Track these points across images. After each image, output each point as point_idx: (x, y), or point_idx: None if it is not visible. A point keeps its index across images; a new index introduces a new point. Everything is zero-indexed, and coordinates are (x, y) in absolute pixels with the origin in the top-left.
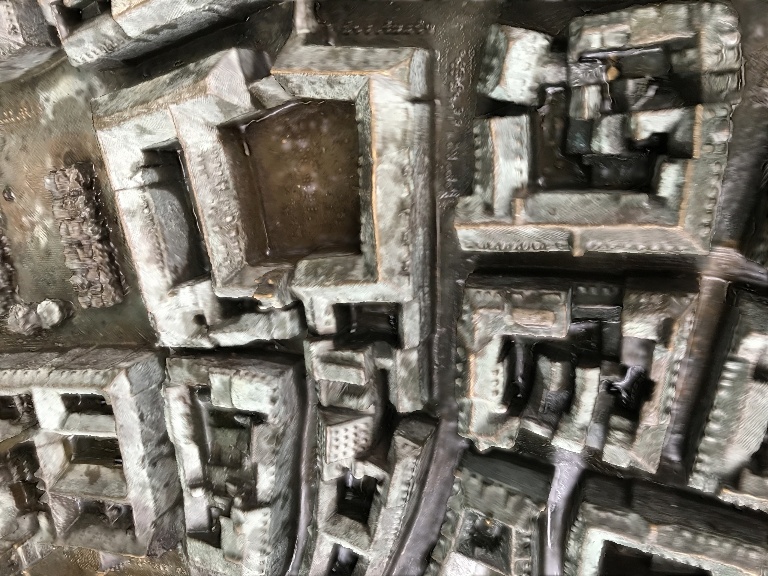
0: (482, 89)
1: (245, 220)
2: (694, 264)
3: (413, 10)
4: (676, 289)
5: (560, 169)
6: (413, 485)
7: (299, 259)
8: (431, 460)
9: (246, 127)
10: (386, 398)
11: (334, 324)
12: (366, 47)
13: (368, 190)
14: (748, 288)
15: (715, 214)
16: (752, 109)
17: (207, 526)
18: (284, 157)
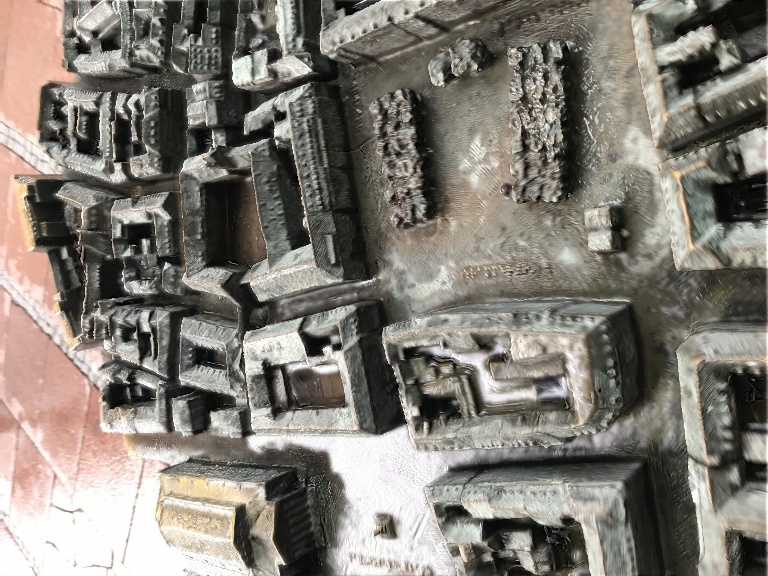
0: (178, 268)
1: None
2: None
3: (227, 308)
4: None
5: None
6: None
7: None
8: None
9: None
10: None
11: None
12: None
13: (191, 222)
14: None
15: None
16: None
17: None
18: None
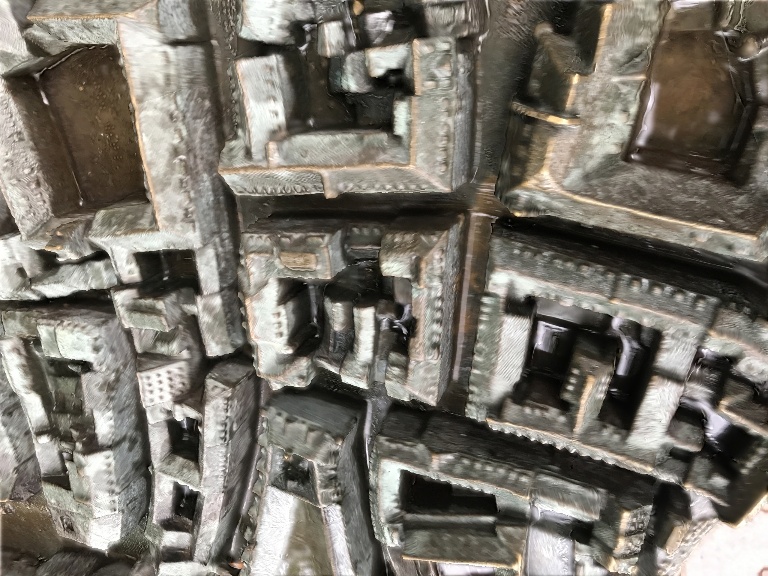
0: (236, 29)
1: (48, 171)
2: (463, 201)
3: None
4: (429, 227)
5: (332, 109)
6: (232, 425)
7: (98, 209)
8: (259, 400)
9: (40, 75)
10: (202, 343)
11: (138, 273)
12: None
13: None
14: (508, 223)
15: (451, 151)
16: (500, 41)
17: (61, 470)
18: (84, 105)
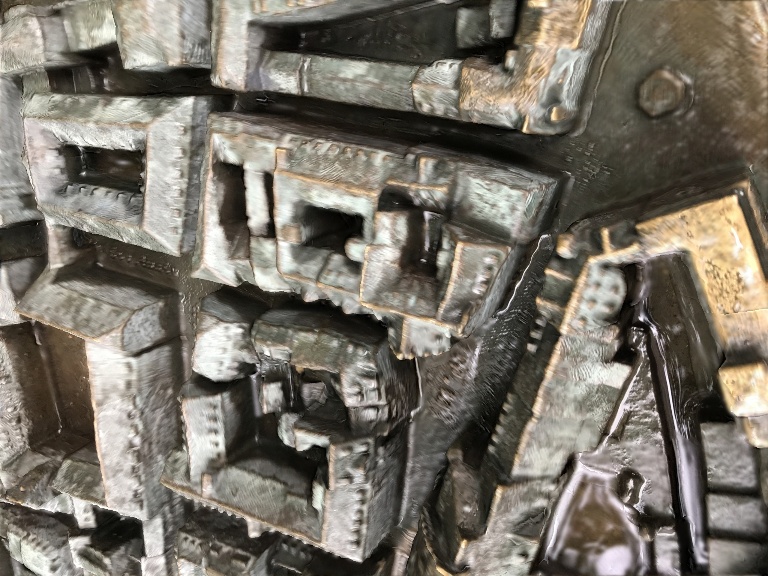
0: None
1: (31, 407)
2: (389, 539)
3: (161, 253)
4: None
5: None
6: None
7: (66, 457)
8: None
9: (36, 321)
10: None
11: (94, 520)
12: (99, 298)
13: None
14: None
15: (364, 531)
16: (431, 417)
17: None
18: (72, 349)
